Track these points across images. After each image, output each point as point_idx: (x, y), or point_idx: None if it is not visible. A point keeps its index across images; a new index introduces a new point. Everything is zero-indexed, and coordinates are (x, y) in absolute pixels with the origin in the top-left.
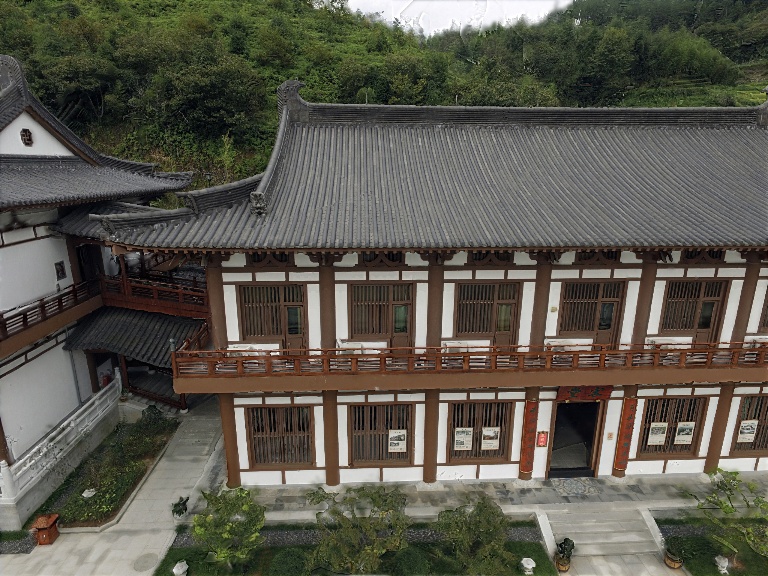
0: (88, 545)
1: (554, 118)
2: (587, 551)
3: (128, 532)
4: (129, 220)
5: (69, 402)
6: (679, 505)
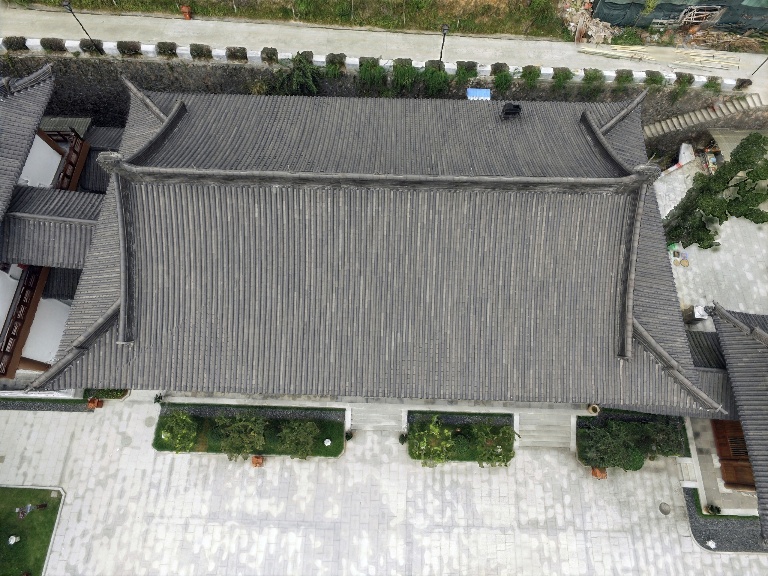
0: (120, 409)
1: (394, 184)
2: (365, 428)
3: (137, 402)
4: (48, 380)
5: (67, 313)
6: (426, 409)
